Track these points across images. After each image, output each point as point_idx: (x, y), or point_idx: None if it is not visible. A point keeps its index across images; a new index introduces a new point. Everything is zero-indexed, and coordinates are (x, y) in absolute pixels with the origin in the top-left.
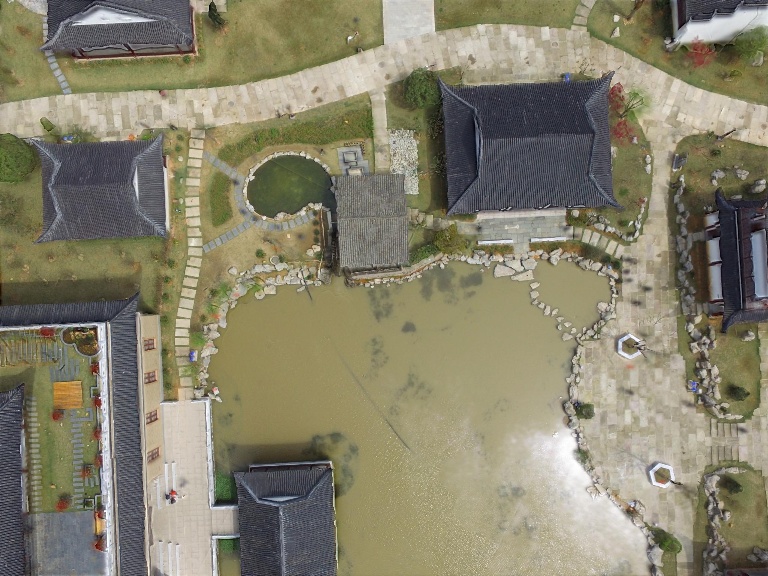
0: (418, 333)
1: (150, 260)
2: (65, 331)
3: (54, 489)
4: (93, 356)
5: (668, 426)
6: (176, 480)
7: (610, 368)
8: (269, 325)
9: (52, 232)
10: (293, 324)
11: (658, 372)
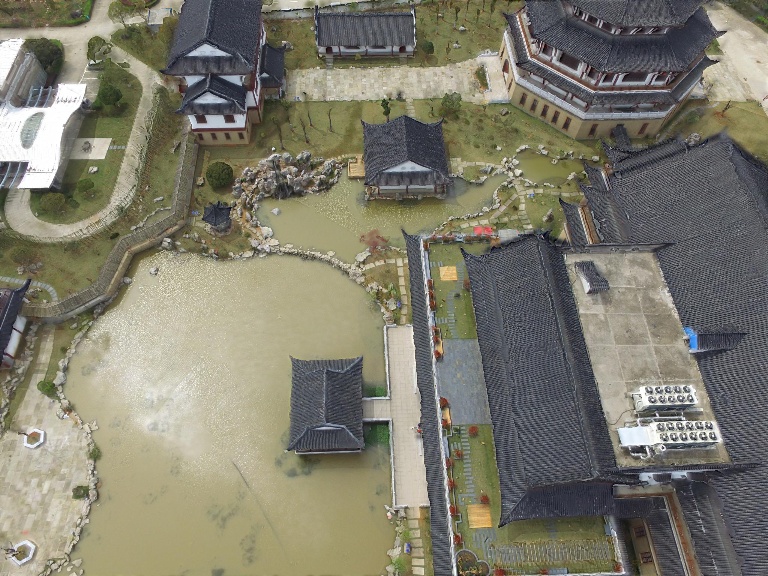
0: (210, 568)
1: None
2: (487, 574)
3: (483, 441)
4: (462, 550)
5: (15, 479)
6: (418, 441)
7: (48, 532)
8: None
9: None
10: None
11: (7, 527)
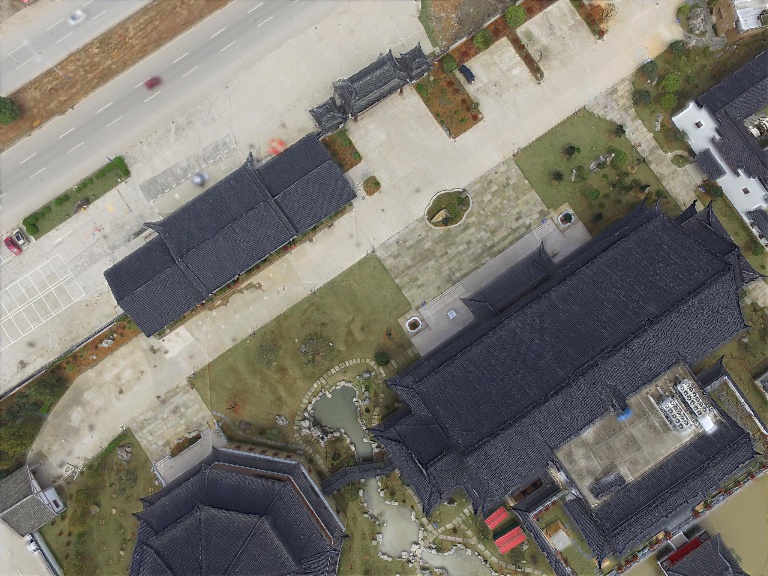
0: None
1: (766, 423)
2: (766, 441)
3: None
4: (763, 459)
5: None
6: None
7: None
8: (758, 488)
9: (767, 384)
10: (767, 500)
11: None
